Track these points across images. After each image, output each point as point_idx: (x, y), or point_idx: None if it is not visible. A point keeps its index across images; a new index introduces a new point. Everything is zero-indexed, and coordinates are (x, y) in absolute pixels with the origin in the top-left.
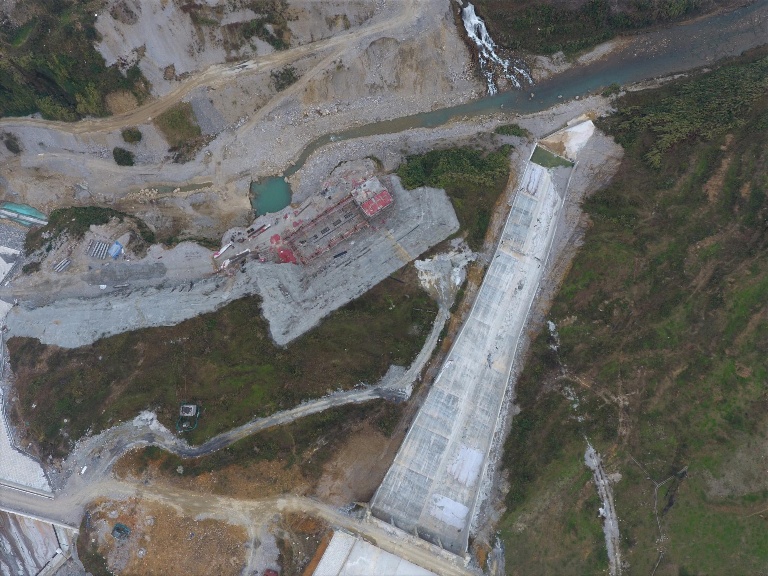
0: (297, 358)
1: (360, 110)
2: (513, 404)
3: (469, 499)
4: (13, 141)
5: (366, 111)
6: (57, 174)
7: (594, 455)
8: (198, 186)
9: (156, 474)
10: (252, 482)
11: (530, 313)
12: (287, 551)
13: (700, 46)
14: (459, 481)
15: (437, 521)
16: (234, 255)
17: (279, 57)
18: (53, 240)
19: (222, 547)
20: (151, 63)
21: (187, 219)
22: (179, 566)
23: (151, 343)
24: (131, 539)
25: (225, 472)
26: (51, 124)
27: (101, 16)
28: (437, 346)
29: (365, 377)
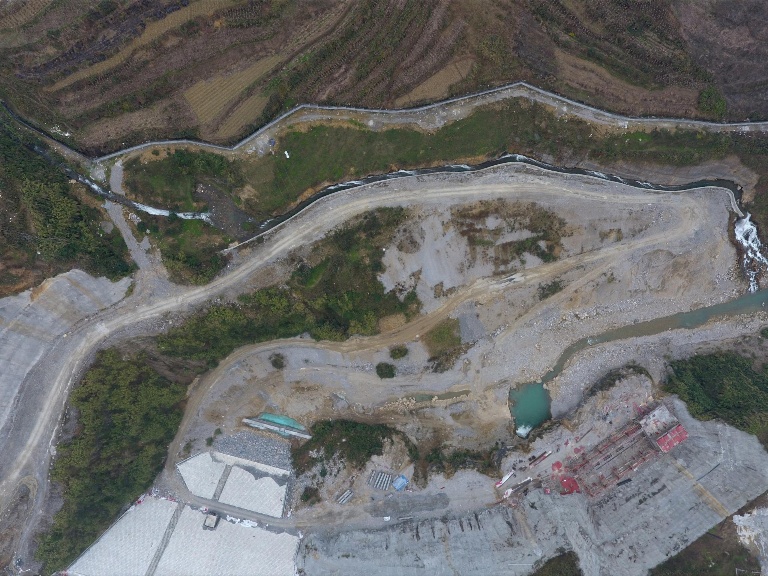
0: None
1: (620, 314)
2: None
3: None
4: (280, 359)
5: (626, 315)
6: (315, 385)
7: None
8: (455, 394)
9: None
10: None
11: None
12: None
13: None
14: None
15: None
16: (516, 484)
17: (547, 269)
18: (325, 462)
19: None
20: (424, 284)
21: (447, 430)
22: None
23: None
24: None
25: None
26: (319, 343)
27: (388, 250)
28: None
29: None
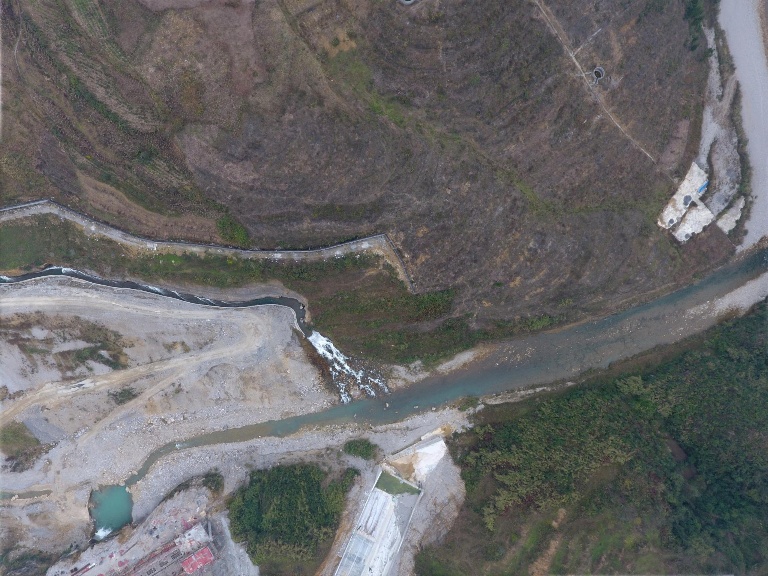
0: None
1: (206, 420)
2: None
3: None
4: None
5: (212, 421)
6: None
7: None
8: (37, 493)
9: None
10: None
11: None
12: None
13: (566, 356)
14: None
15: None
16: None
17: (117, 377)
18: None
19: None
20: None
21: (23, 530)
22: None
23: None
24: None
25: None
26: None
27: None
28: None
29: None
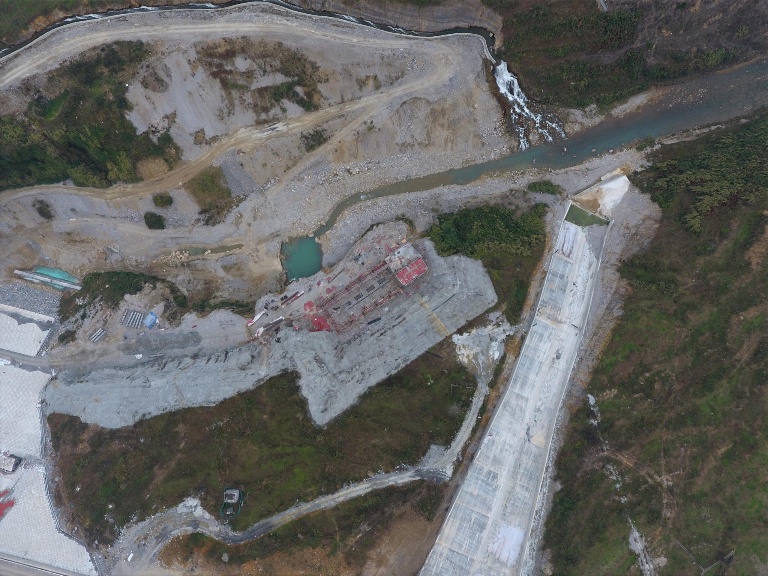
0: (337, 439)
1: (390, 168)
2: (553, 480)
3: None
4: (45, 208)
5: (396, 169)
6: (89, 238)
7: (639, 539)
8: (229, 248)
9: (202, 562)
10: (297, 570)
11: (568, 384)
12: None
13: (738, 95)
14: (500, 560)
15: None
16: (268, 323)
17: (309, 118)
18: (87, 307)
19: None
20: (181, 129)
21: (218, 282)
22: None
23: (192, 425)
24: None
25: (270, 560)
26: (83, 191)
27: (132, 86)
28: (477, 423)
29: (406, 458)
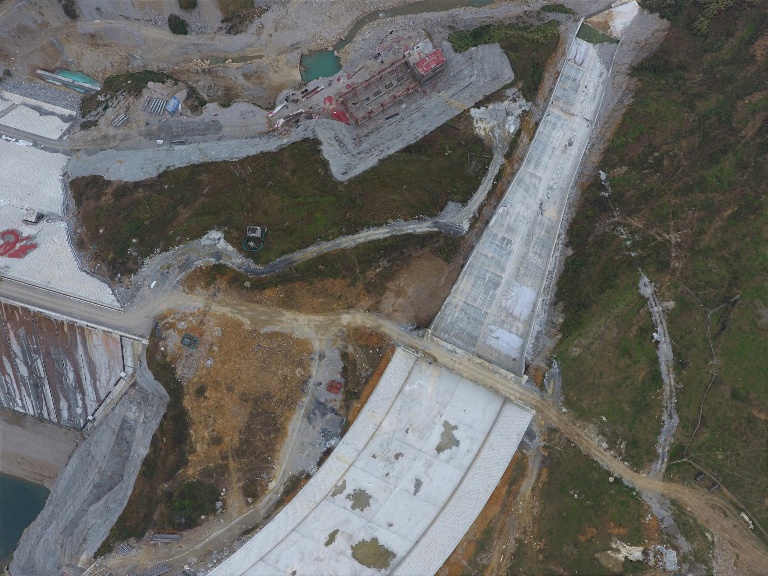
0: (358, 191)
1: None
2: (565, 246)
3: (523, 332)
4: (71, 5)
5: None
6: (112, 42)
7: (648, 284)
8: (249, 58)
9: (224, 287)
10: (317, 297)
11: (580, 167)
12: (351, 363)
13: None
14: (513, 315)
15: (493, 350)
16: (288, 115)
17: None
18: (109, 101)
19: (288, 359)
20: None
21: (239, 89)
22: (246, 376)
23: (216, 174)
24: (199, 349)
25: (291, 287)
26: None
27: None
28: (492, 187)
29: (424, 210)
